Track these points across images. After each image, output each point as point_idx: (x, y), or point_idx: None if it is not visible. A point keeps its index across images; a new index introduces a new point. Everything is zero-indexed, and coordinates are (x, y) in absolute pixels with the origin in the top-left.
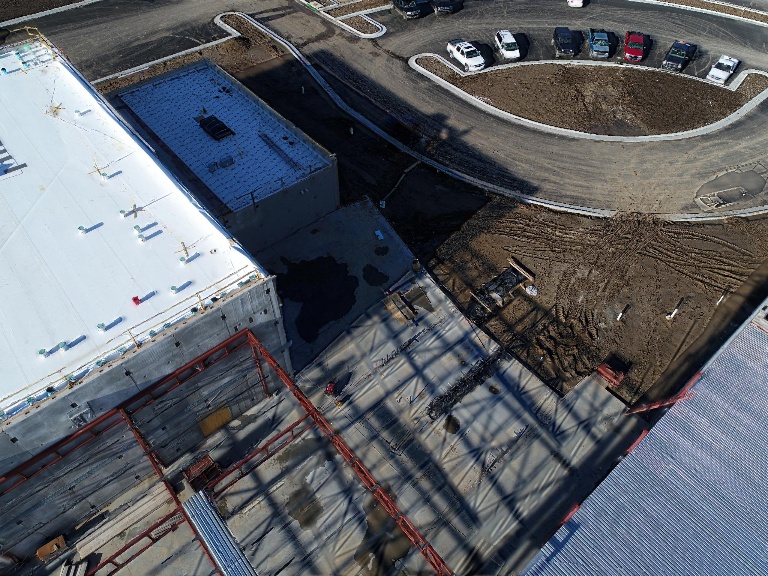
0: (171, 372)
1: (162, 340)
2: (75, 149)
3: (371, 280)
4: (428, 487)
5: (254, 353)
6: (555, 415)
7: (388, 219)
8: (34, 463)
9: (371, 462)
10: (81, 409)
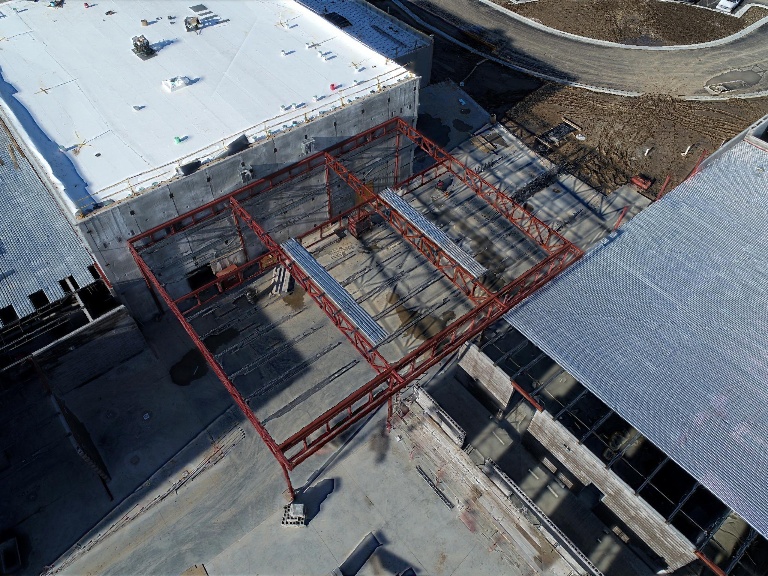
0: (354, 135)
1: (357, 104)
2: (260, 12)
3: (460, 128)
4: (514, 239)
5: (397, 141)
6: (601, 205)
7: (467, 93)
8: (278, 175)
9: (473, 226)
10: (310, 140)
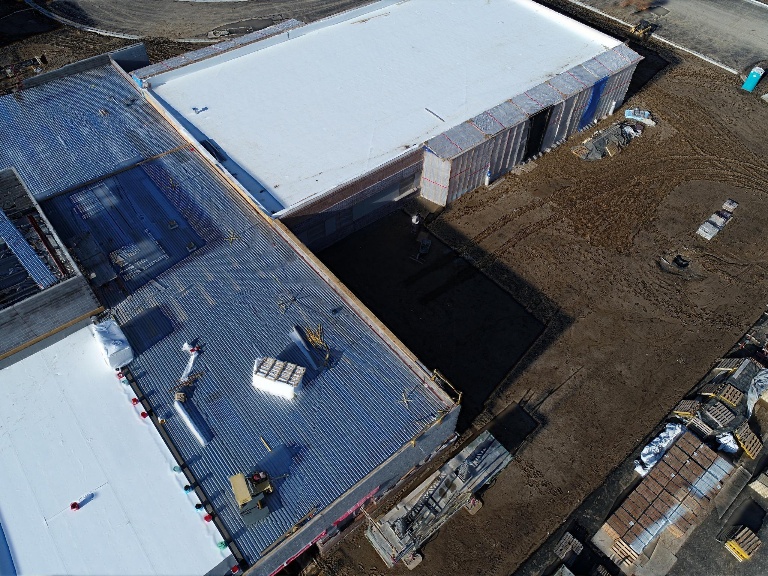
0: None
1: None
2: None
3: None
4: None
5: None
6: None
7: None
8: None
9: None
10: None
